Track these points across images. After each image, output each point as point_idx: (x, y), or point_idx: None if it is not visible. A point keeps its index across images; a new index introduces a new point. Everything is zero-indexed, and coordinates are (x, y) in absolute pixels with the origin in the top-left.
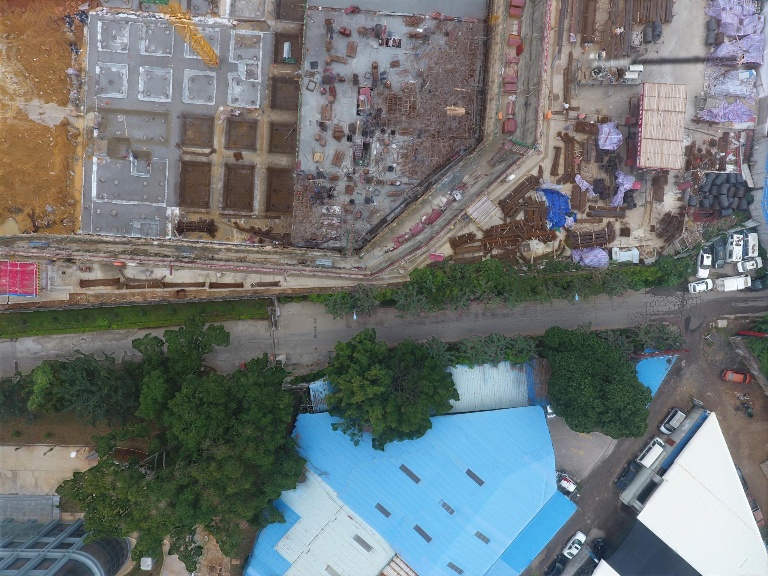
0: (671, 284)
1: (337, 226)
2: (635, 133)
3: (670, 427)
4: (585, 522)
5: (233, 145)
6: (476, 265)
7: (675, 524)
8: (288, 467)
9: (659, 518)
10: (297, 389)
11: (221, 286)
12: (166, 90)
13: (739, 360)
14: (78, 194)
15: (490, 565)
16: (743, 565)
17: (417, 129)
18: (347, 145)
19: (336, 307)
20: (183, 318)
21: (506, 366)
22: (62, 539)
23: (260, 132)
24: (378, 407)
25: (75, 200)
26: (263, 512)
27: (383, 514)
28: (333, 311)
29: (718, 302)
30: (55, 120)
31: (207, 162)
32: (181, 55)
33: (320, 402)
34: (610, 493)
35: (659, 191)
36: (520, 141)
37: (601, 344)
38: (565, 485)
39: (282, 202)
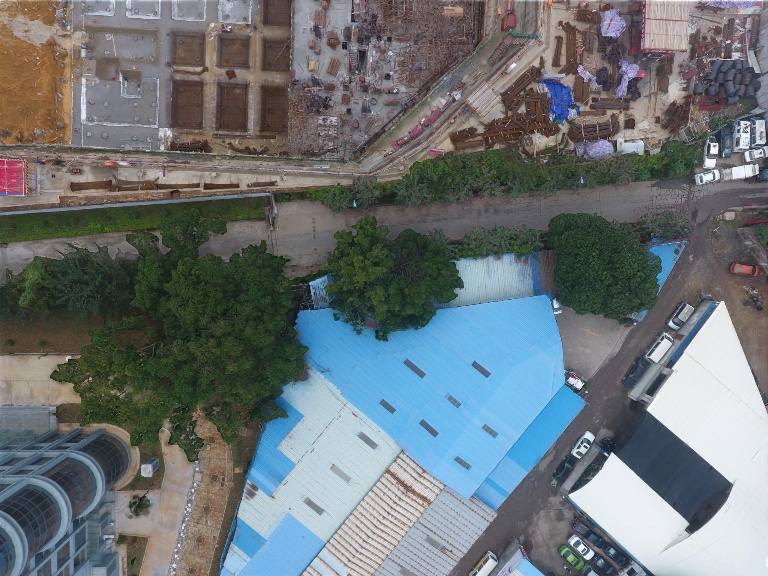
0: (678, 171)
1: (334, 137)
2: (638, 21)
3: (679, 321)
4: (594, 422)
5: (225, 63)
6: (478, 156)
7: (686, 416)
8: (290, 351)
9: (669, 410)
10: (297, 288)
11: (216, 187)
12: (155, 7)
13: (748, 253)
14: (67, 117)
15: (498, 461)
16: (755, 457)
17: (414, 35)
18: (342, 53)
19: (335, 200)
20: None
21: (511, 259)
22: (60, 443)
23: (253, 49)
24: (381, 290)
25: (64, 123)
26: (265, 407)
27: (388, 410)
28: (332, 203)
29: (725, 194)
30: (41, 38)
31: (199, 81)
32: None
33: (321, 300)
34: (618, 392)
35: (663, 81)
36: (520, 33)
37: (608, 224)
38: (573, 382)
39: (277, 122)
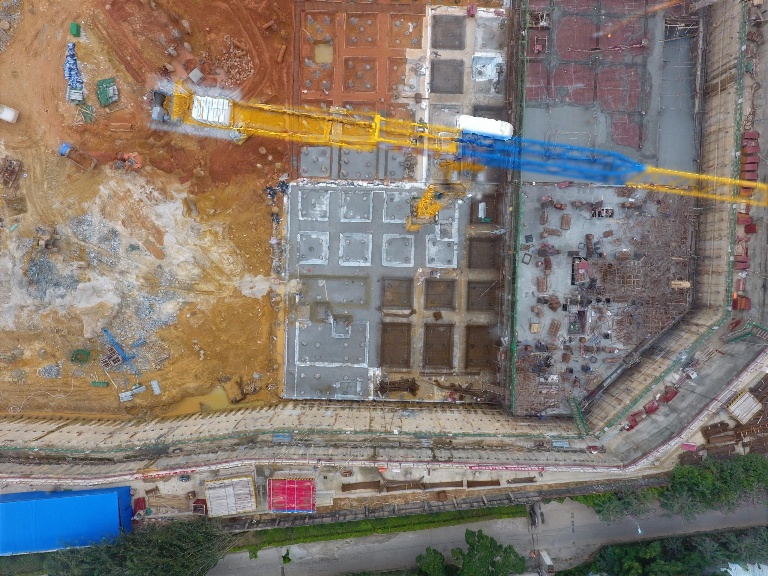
0: None
1: (555, 394)
2: None
3: None
4: None
5: (431, 304)
6: (740, 462)
7: None
8: None
9: None
10: None
11: (479, 485)
12: (364, 254)
13: None
14: (280, 358)
15: None
16: None
17: (631, 296)
18: (562, 314)
19: (608, 513)
20: (444, 519)
21: None
22: None
23: (458, 291)
24: None
25: (278, 364)
26: None
27: None
28: (607, 518)
29: None
30: (263, 291)
31: (407, 323)
32: (380, 220)
33: None
34: None
35: None
36: (764, 327)
37: None
38: None
39: (479, 357)
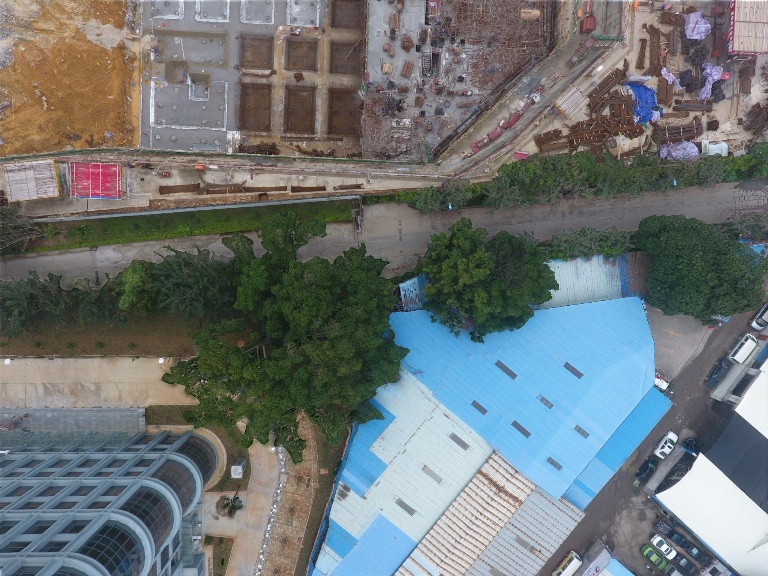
0: (765, 173)
1: (407, 140)
2: (721, 24)
3: (762, 322)
4: (676, 422)
5: (293, 66)
6: (566, 158)
7: None
8: (394, 353)
9: (757, 410)
10: None
11: (303, 189)
12: (223, 11)
13: None
14: (136, 120)
15: (588, 461)
16: None
17: (487, 38)
18: (416, 56)
19: (427, 202)
20: None
21: (599, 260)
22: (154, 445)
23: (320, 52)
24: (483, 292)
25: (133, 126)
26: (362, 408)
27: (480, 411)
28: (424, 206)
29: None
30: (112, 42)
31: (267, 84)
32: None
33: (411, 302)
34: (701, 392)
35: (746, 83)
36: (603, 35)
37: (704, 226)
38: (658, 383)
39: (344, 124)
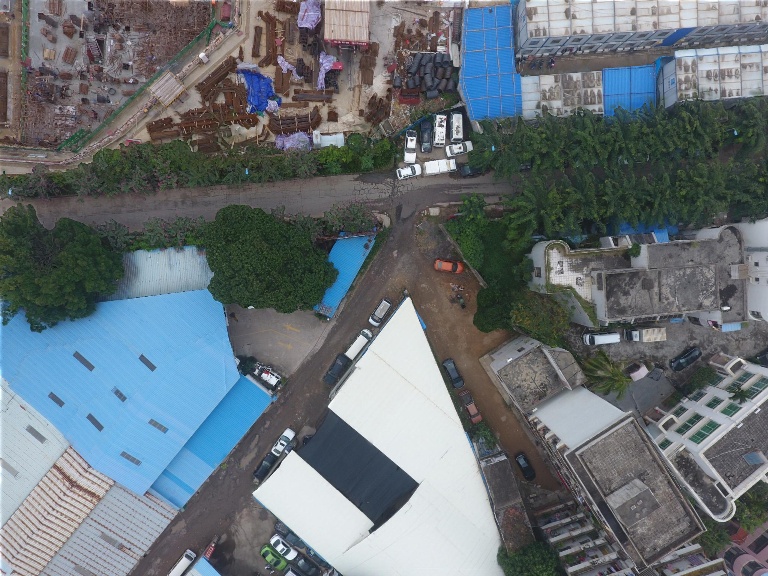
0: (364, 165)
1: (72, 127)
2: None
3: (377, 318)
4: (296, 419)
5: None
6: (160, 146)
7: (369, 414)
8: None
9: (352, 407)
10: None
11: None
12: None
13: (452, 249)
14: None
15: (173, 457)
16: (443, 456)
17: (152, 25)
18: (80, 42)
19: (5, 188)
20: None
21: (193, 251)
22: None
23: (11, 37)
24: (12, 279)
25: None
26: None
27: (57, 404)
28: (0, 191)
29: (430, 189)
30: None
31: None
32: None
33: None
34: (321, 389)
35: (367, 74)
36: None
37: (260, 216)
38: (266, 378)
39: None
